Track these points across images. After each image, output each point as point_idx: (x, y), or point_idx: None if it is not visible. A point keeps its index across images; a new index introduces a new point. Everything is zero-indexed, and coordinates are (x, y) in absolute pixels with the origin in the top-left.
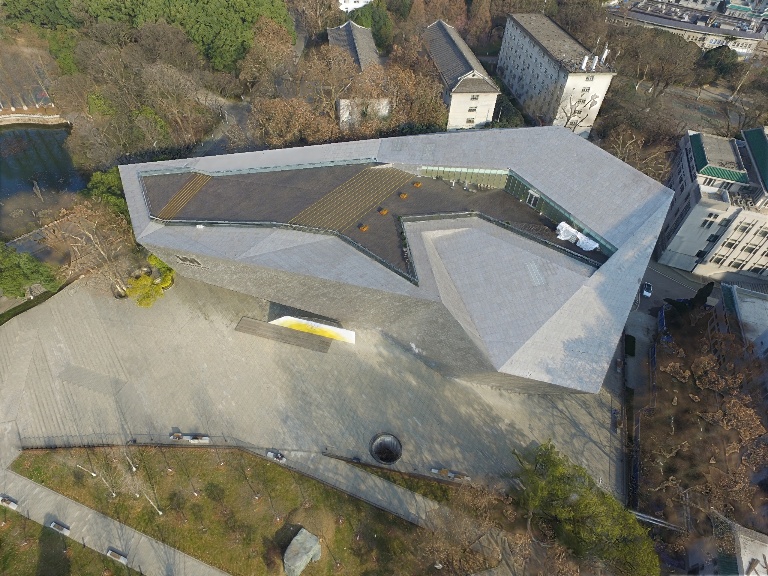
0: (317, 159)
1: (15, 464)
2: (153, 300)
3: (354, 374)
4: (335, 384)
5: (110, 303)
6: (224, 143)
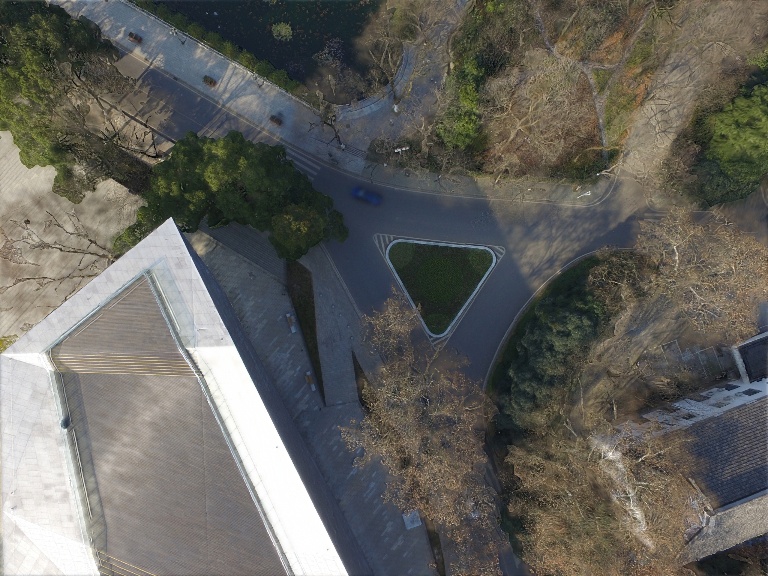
0: (299, 543)
1: None
2: None
3: None
4: None
5: None
6: (514, 219)
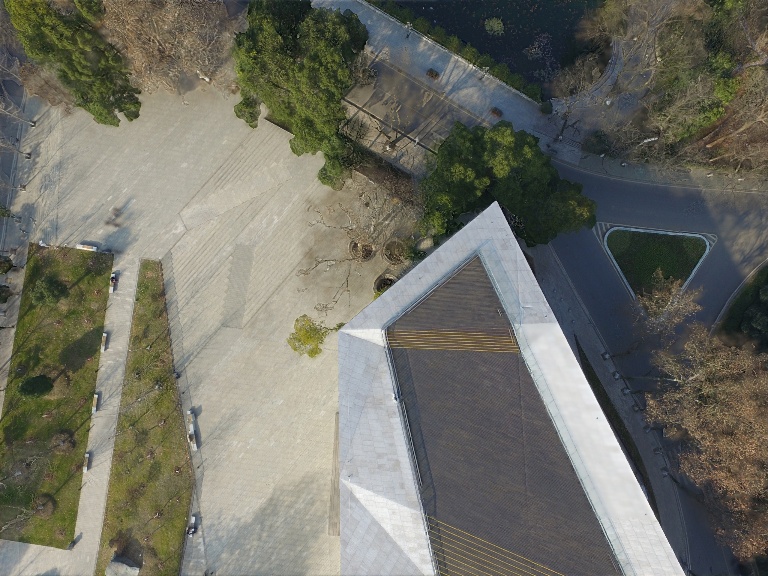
0: (614, 509)
1: (146, 263)
2: (299, 353)
3: (307, 575)
4: (289, 558)
5: (341, 242)
6: (726, 208)
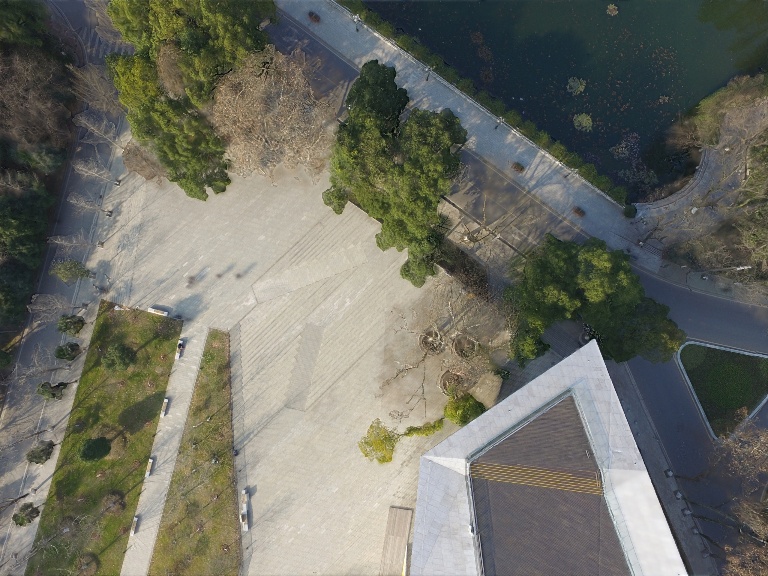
0: None
1: (214, 333)
2: (369, 458)
3: None
4: None
5: None
6: None
